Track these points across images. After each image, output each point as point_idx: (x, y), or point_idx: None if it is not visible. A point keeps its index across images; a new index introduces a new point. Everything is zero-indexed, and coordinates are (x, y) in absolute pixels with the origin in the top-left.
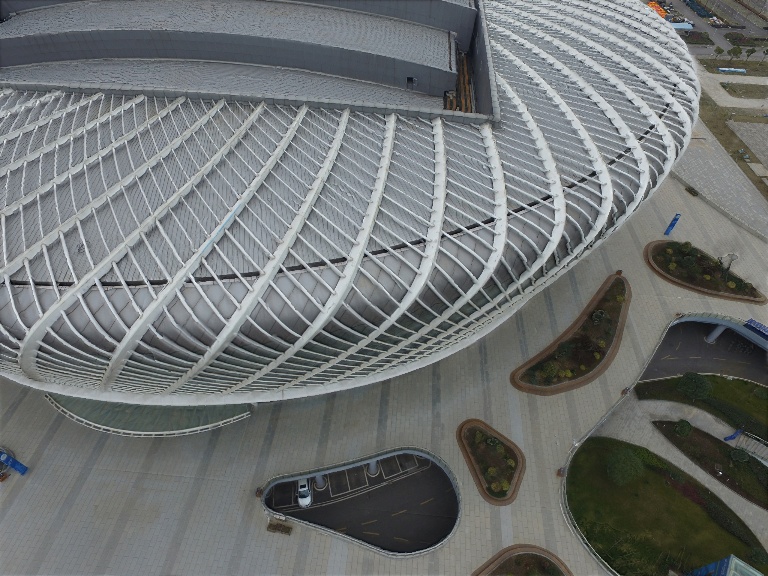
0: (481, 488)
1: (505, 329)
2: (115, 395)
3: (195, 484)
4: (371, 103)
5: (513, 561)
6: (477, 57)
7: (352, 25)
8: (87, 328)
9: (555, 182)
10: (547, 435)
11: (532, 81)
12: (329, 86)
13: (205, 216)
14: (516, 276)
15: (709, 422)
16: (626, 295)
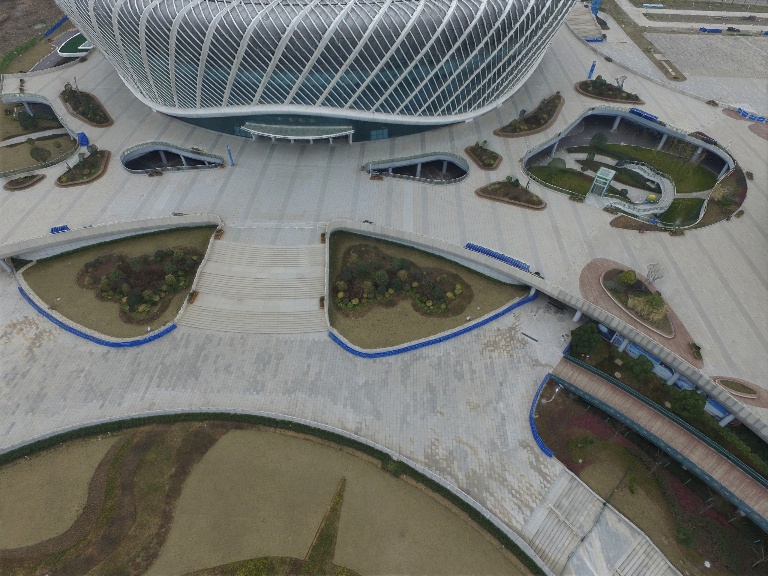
0: (479, 165)
1: (489, 116)
2: (291, 107)
3: (327, 167)
4: None
5: (497, 183)
6: None
7: None
8: (316, 20)
9: None
10: (514, 150)
11: None
12: None
13: None
14: (493, 22)
15: (608, 160)
16: (561, 101)
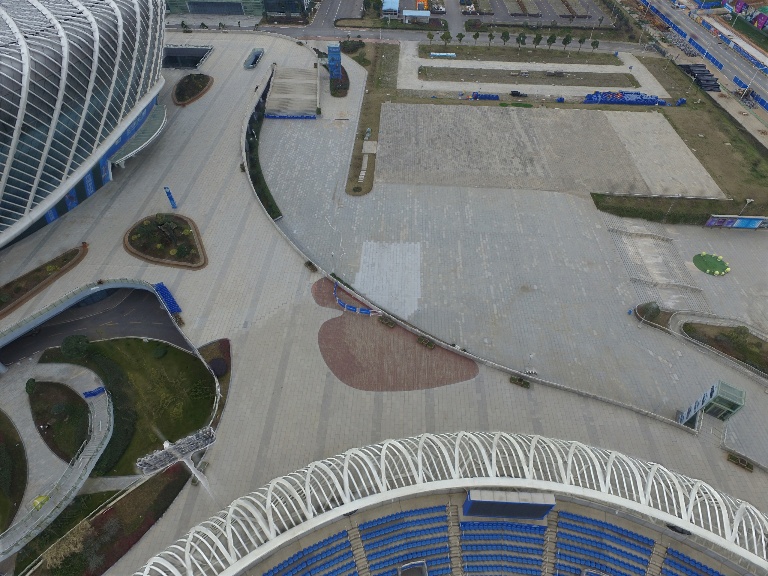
0: None
1: None
2: None
3: None
4: None
5: None
6: None
7: None
8: None
9: None
10: None
11: None
12: None
13: None
14: None
15: (87, 381)
16: (66, 265)
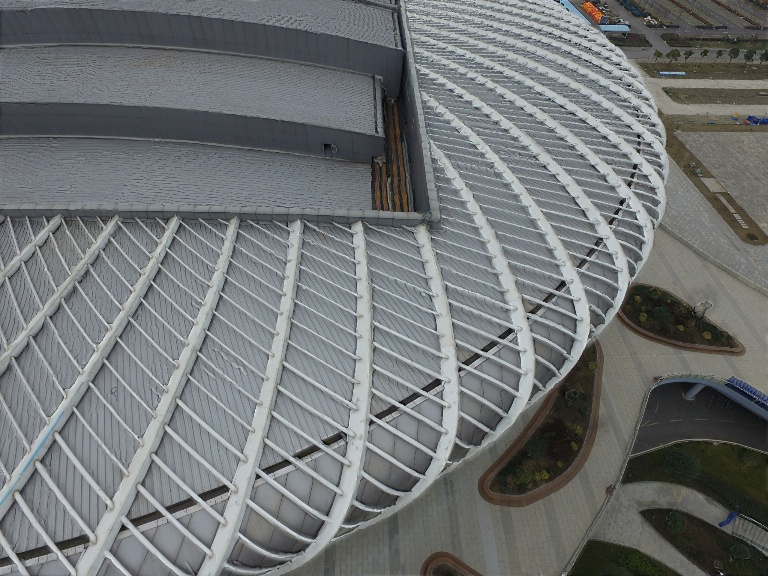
0: None
1: None
2: None
3: None
4: (267, 208)
5: None
6: (408, 109)
7: (252, 77)
8: None
9: (517, 308)
10: (527, 564)
11: (476, 150)
12: (224, 162)
13: (6, 439)
14: (477, 445)
15: (700, 504)
16: (598, 359)
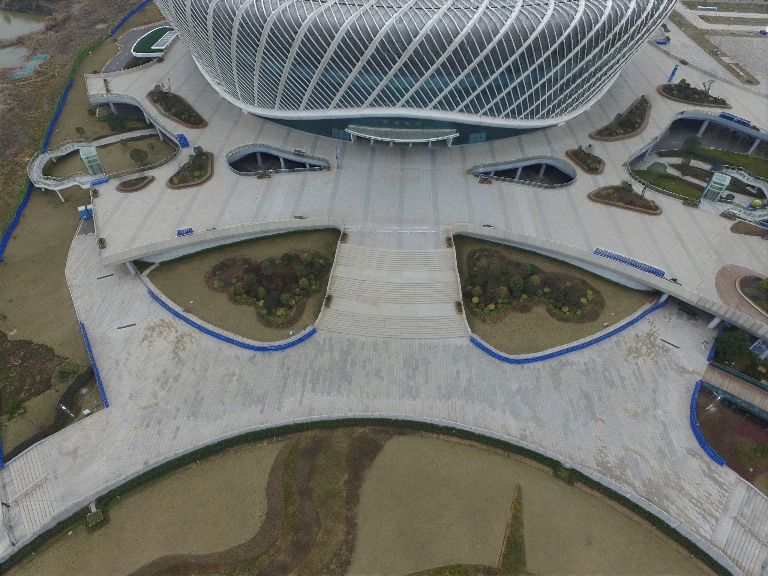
0: (584, 170)
1: (580, 119)
2: (402, 110)
3: (432, 171)
4: None
5: (608, 187)
6: None
7: None
8: (449, 24)
9: None
10: (614, 154)
11: None
12: None
13: None
14: None
15: (701, 164)
16: (649, 105)
